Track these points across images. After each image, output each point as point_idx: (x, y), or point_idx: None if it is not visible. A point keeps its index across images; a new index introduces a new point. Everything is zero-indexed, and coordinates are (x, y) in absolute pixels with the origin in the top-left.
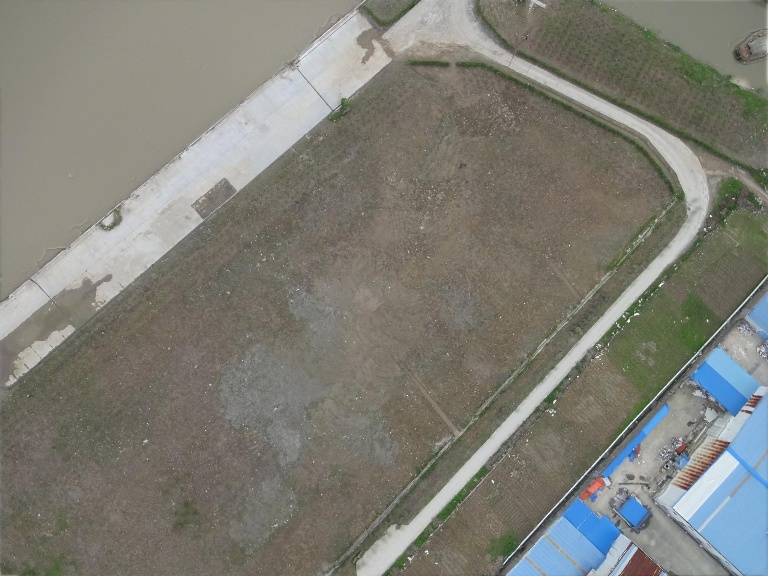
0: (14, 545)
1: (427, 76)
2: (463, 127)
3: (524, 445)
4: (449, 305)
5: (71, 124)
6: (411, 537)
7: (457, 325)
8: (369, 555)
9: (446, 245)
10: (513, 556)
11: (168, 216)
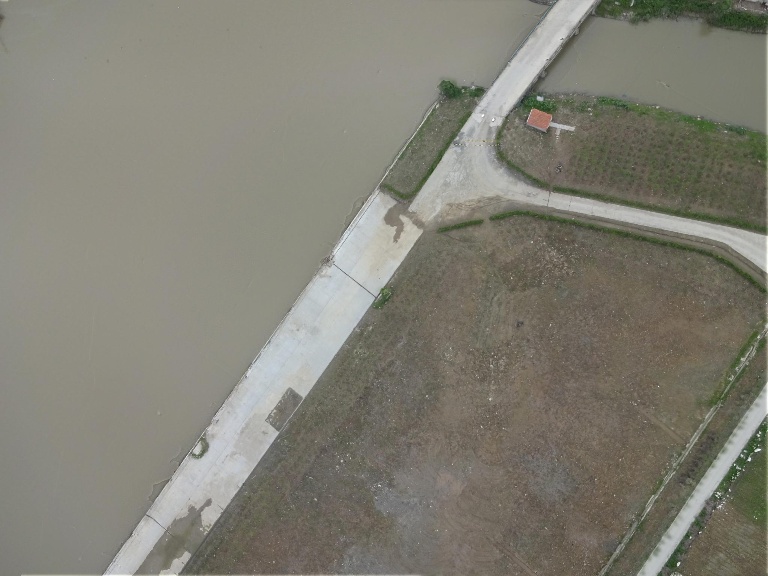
0: None
1: (462, 239)
2: (511, 283)
3: None
4: (536, 476)
5: (150, 365)
6: None
7: (549, 496)
8: None
9: (520, 412)
10: None
11: (247, 435)
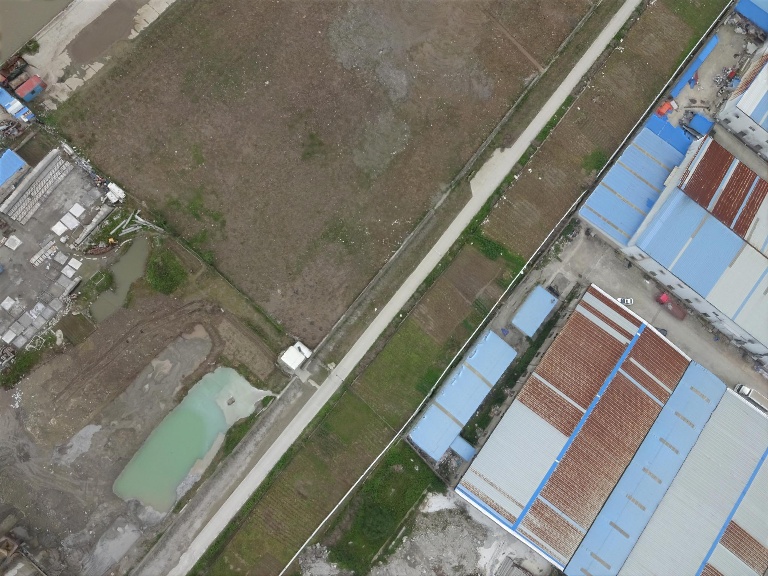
0: (156, 180)
1: None
2: None
3: (601, 77)
4: None
5: None
6: (515, 158)
7: None
8: (480, 175)
9: None
10: (604, 170)
11: None
